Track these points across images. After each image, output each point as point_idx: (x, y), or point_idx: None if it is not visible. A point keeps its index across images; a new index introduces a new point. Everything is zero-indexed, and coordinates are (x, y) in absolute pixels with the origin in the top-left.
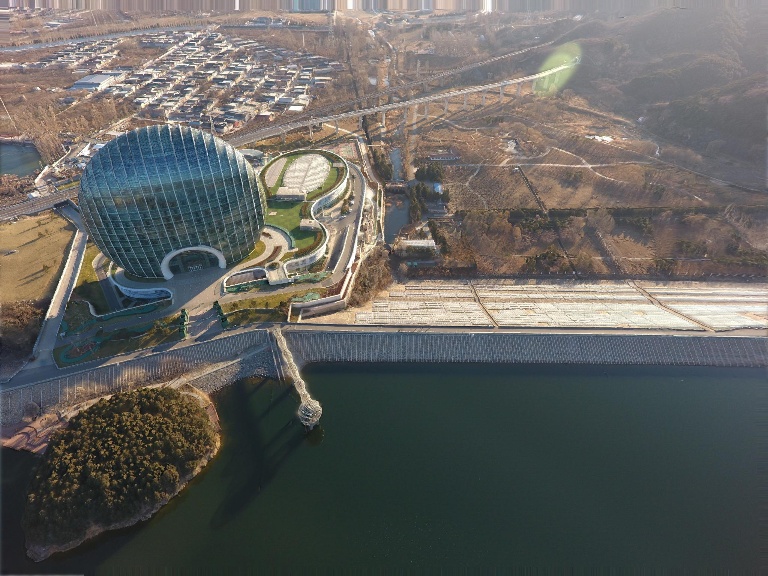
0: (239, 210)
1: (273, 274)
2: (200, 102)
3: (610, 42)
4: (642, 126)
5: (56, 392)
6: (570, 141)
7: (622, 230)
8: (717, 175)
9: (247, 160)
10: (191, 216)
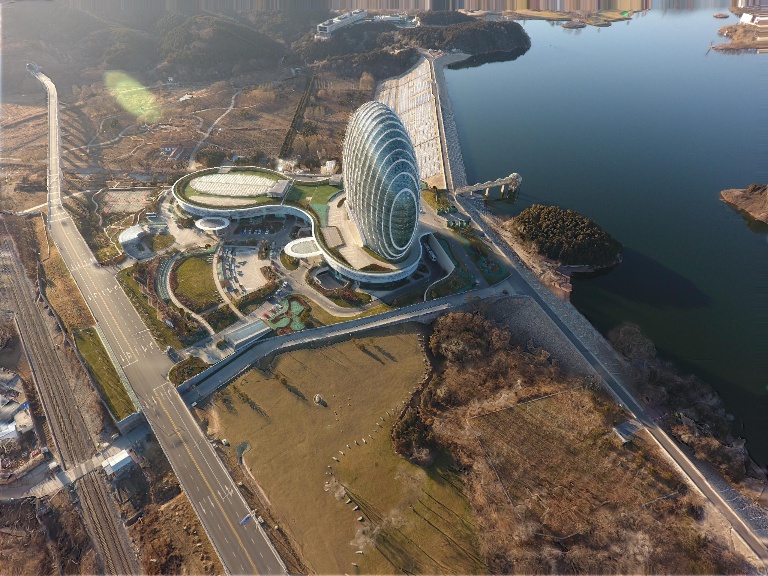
0: None
1: None
2: None
3: (34, 41)
4: None
5: (528, 275)
6: None
7: None
8: None
9: (143, 239)
10: None
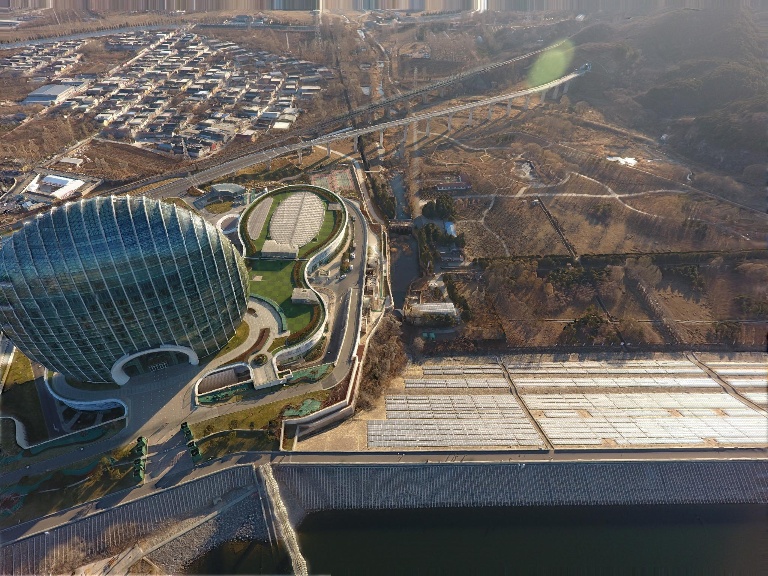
0: (213, 299)
1: (259, 373)
2: (172, 119)
3: (622, 47)
4: (666, 145)
5: None
6: (591, 164)
7: (668, 282)
8: (760, 207)
9: (226, 197)
10: (148, 314)
